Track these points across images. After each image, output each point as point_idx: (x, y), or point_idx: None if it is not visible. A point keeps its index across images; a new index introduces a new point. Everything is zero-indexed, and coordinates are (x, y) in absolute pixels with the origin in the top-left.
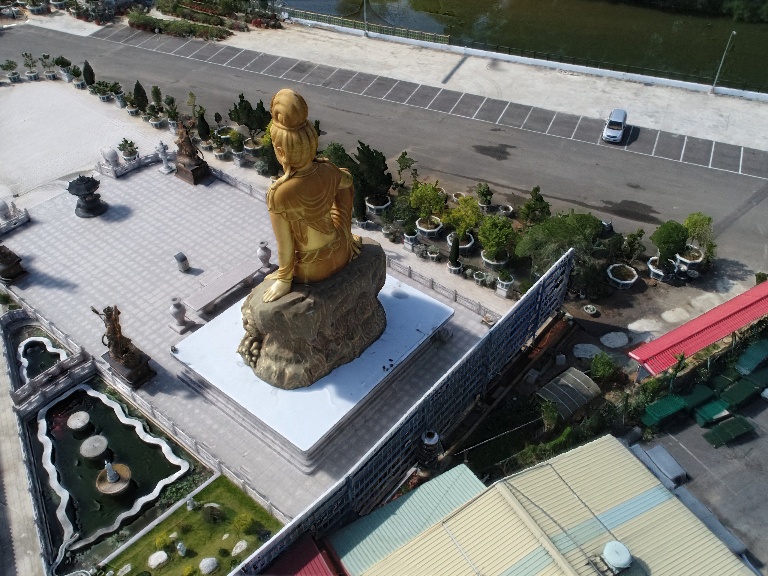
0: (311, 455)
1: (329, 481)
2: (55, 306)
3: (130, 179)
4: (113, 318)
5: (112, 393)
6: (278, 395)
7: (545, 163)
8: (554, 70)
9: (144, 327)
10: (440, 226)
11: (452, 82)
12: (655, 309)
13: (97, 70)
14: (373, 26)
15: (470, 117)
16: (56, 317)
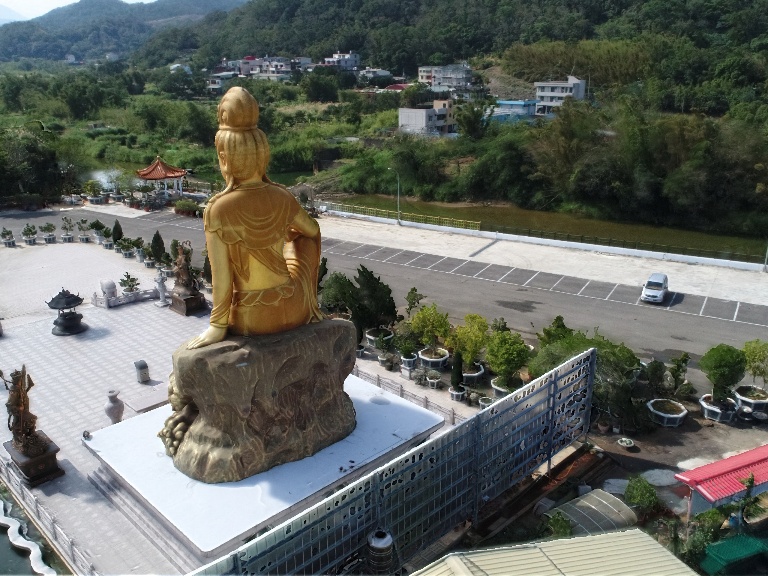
0: None
1: None
2: None
3: (122, 309)
4: None
5: (2, 491)
6: (194, 488)
7: (575, 316)
8: (589, 251)
9: (73, 429)
10: (446, 356)
11: (480, 256)
12: (713, 449)
13: (131, 238)
14: (406, 215)
15: (495, 280)
16: None
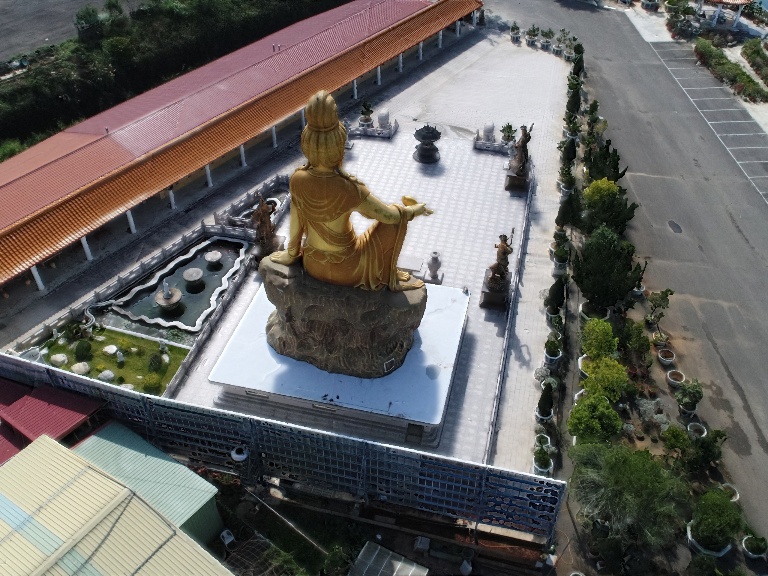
0: (227, 393)
1: None
2: None
3: (480, 155)
4: (264, 209)
5: None
6: (260, 338)
7: None
8: None
9: None
10: None
11: None
12: None
13: (607, 70)
14: None
15: None
16: None
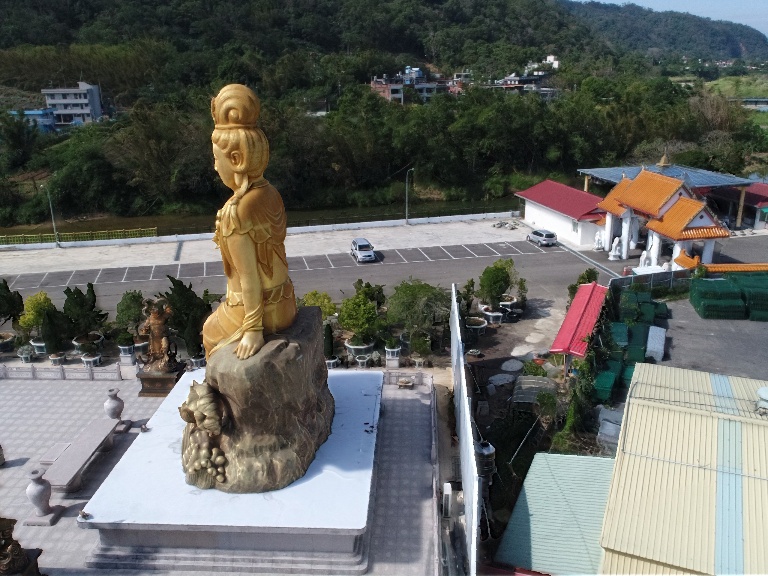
0: (355, 548)
1: (394, 567)
2: None
3: None
4: None
5: None
6: (276, 497)
7: (329, 285)
8: None
9: None
10: None
11: (185, 258)
12: (517, 339)
13: None
14: (65, 235)
15: None
16: None
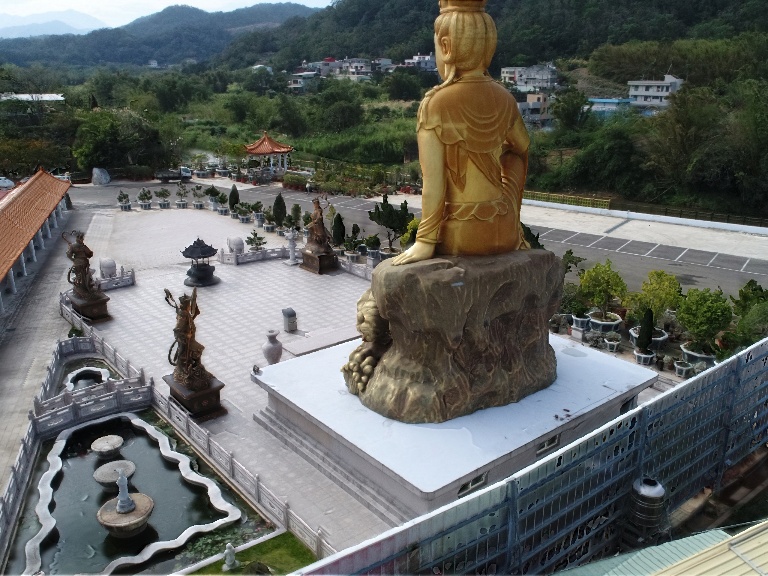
0: None
1: (460, 564)
2: (129, 345)
3: (251, 266)
4: None
5: (163, 426)
6: (392, 427)
7: None
8: (737, 232)
9: (226, 371)
10: (619, 320)
11: (616, 233)
12: None
13: None
14: (526, 193)
15: (642, 254)
16: (126, 354)
